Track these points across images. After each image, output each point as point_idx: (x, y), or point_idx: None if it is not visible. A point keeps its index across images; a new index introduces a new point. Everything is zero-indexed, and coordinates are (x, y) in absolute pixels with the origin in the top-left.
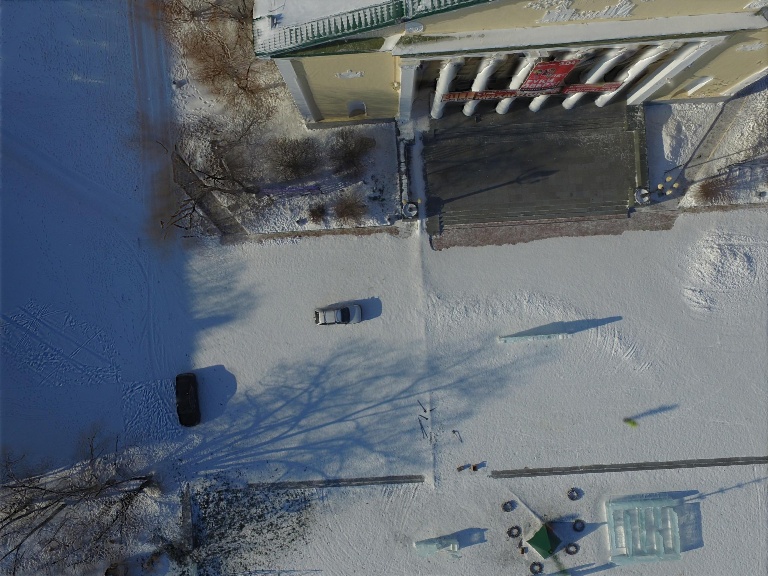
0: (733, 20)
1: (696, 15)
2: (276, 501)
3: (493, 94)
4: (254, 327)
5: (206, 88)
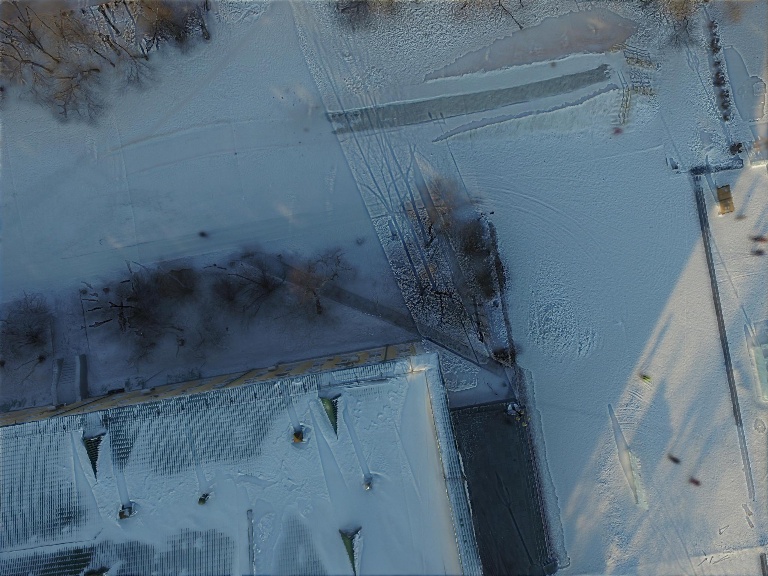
0: None
1: None
2: None
3: None
4: None
5: None
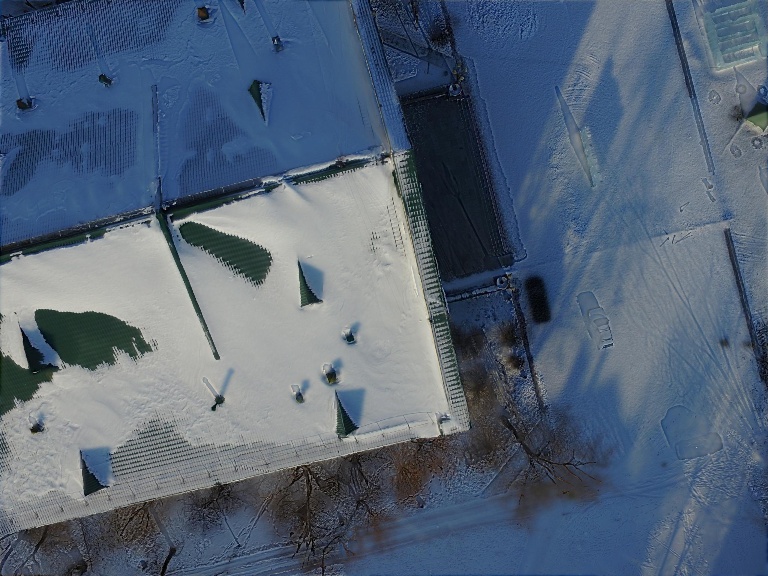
0: None
1: None
2: None
3: None
4: (622, 400)
5: None
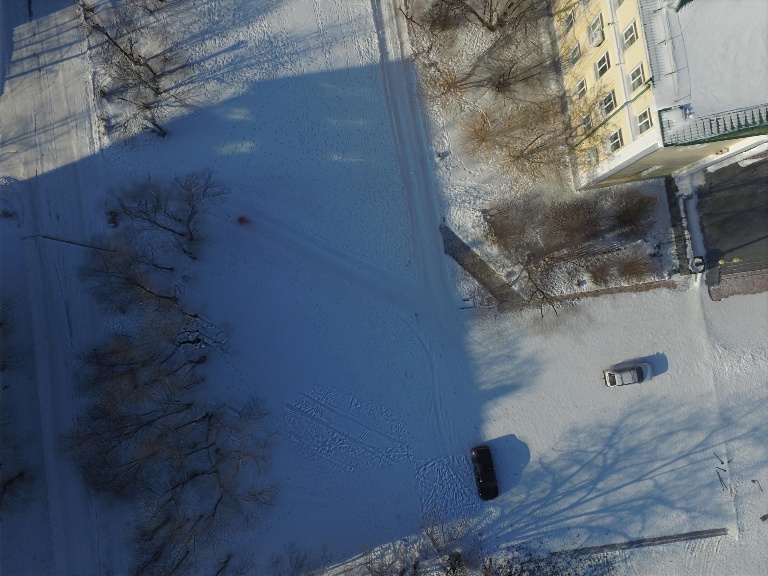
0: None
1: None
2: (578, 567)
3: None
4: (541, 393)
5: (470, 158)
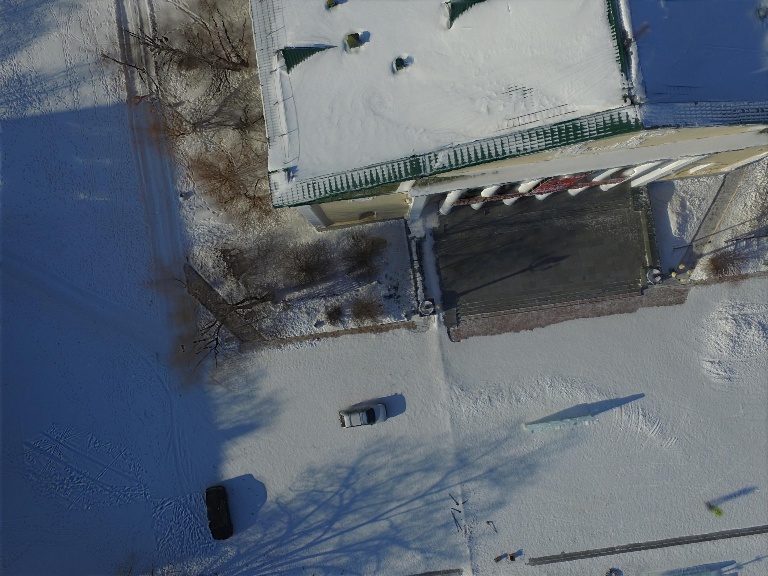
0: (740, 140)
1: (703, 138)
2: None
3: (502, 197)
4: (280, 433)
5: (213, 198)
